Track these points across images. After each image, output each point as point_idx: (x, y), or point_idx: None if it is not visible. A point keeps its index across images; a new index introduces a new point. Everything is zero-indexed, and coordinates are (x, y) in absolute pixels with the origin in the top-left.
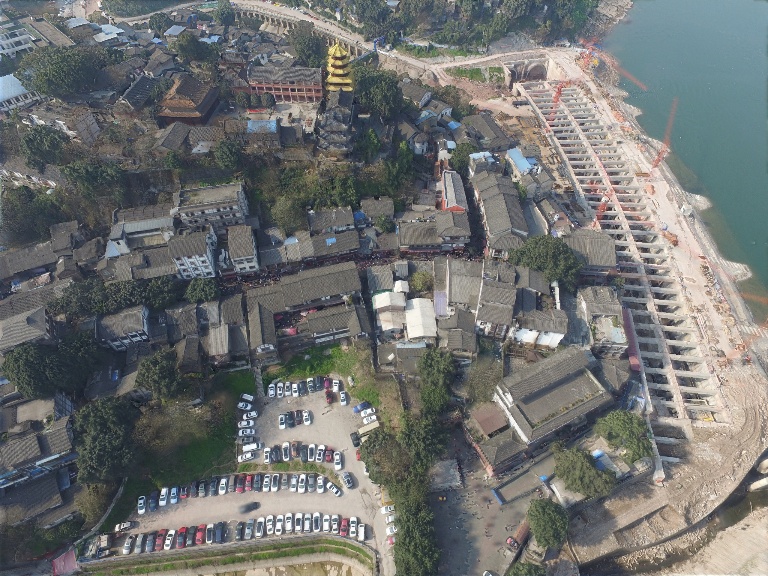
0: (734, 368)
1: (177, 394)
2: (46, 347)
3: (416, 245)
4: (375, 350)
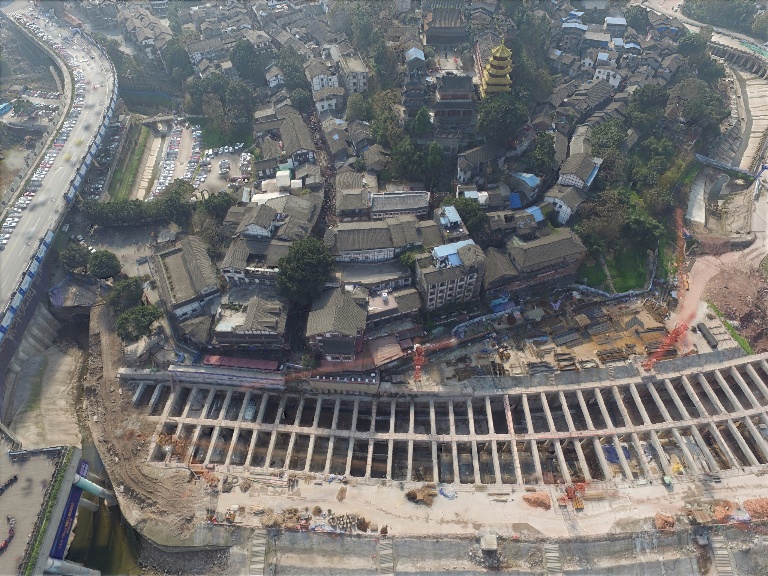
0: (206, 496)
1: (228, 103)
2: (251, 50)
3: None
4: None
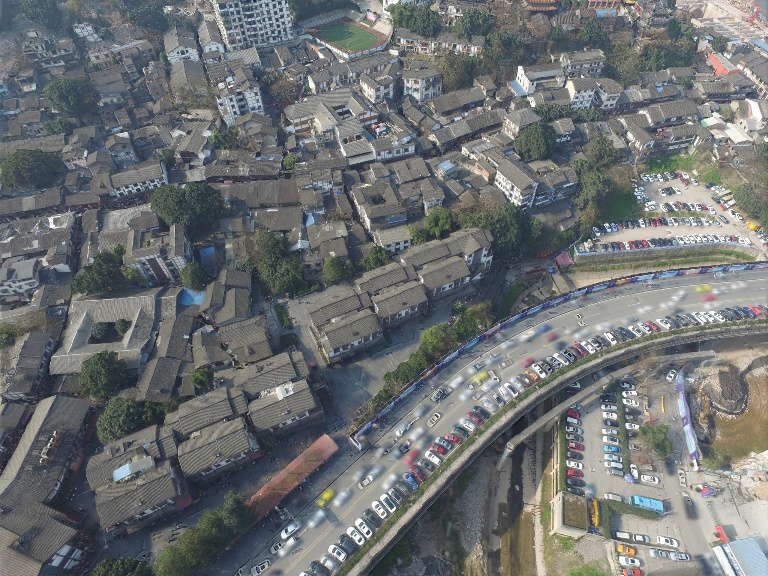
0: None
1: (616, 162)
2: None
3: (713, 95)
4: (711, 152)
